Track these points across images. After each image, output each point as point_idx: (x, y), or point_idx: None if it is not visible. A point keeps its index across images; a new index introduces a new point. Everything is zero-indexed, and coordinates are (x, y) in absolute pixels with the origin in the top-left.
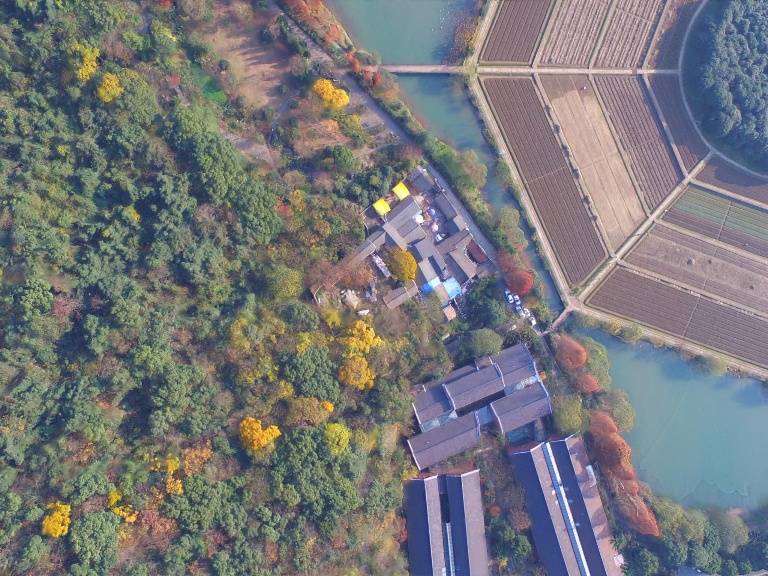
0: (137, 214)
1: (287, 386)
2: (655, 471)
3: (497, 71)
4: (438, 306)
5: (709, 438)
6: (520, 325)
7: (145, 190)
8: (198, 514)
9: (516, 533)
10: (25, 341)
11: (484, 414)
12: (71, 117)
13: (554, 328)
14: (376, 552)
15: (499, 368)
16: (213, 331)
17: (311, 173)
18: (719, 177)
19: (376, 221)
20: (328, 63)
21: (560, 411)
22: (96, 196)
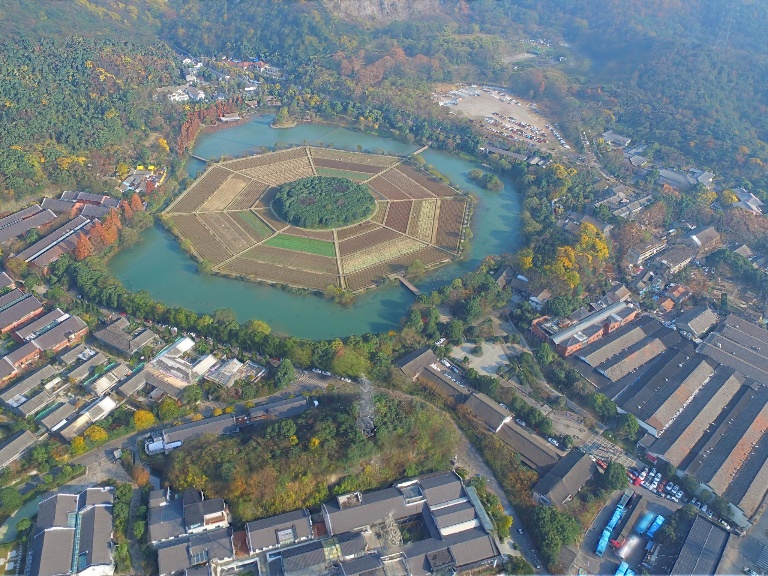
0: None
1: (41, 148)
2: None
3: None
4: None
5: None
6: None
7: None
8: None
9: None
10: (3, 112)
11: None
12: None
13: None
14: None
15: None
16: None
17: None
18: None
19: None
20: None
21: None
22: None
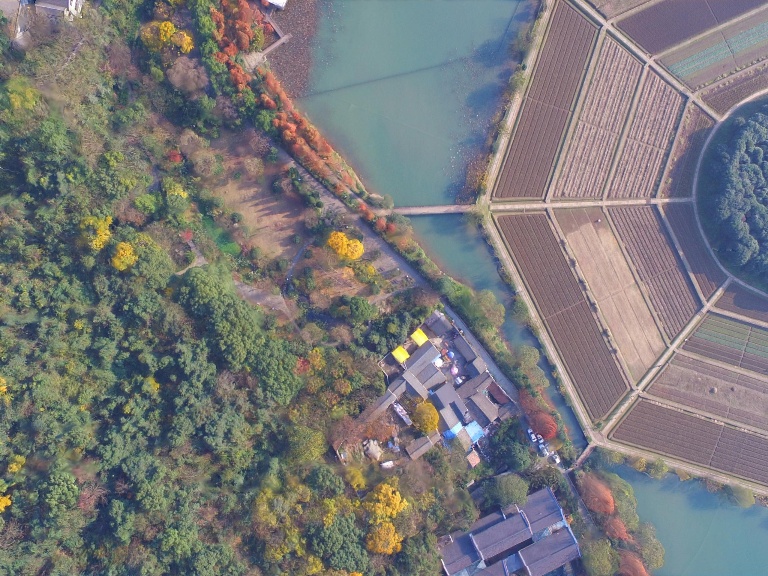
0: (157, 384)
1: (316, 562)
2: None
3: (510, 208)
4: (461, 452)
5: (739, 565)
6: (544, 464)
7: (164, 361)
8: None
9: None
10: (51, 536)
11: (512, 562)
12: (86, 284)
13: (578, 465)
14: None
15: (526, 516)
16: (238, 505)
17: (328, 320)
18: (738, 303)
19: (395, 368)
20: (340, 209)
21: (589, 555)
22: (114, 366)
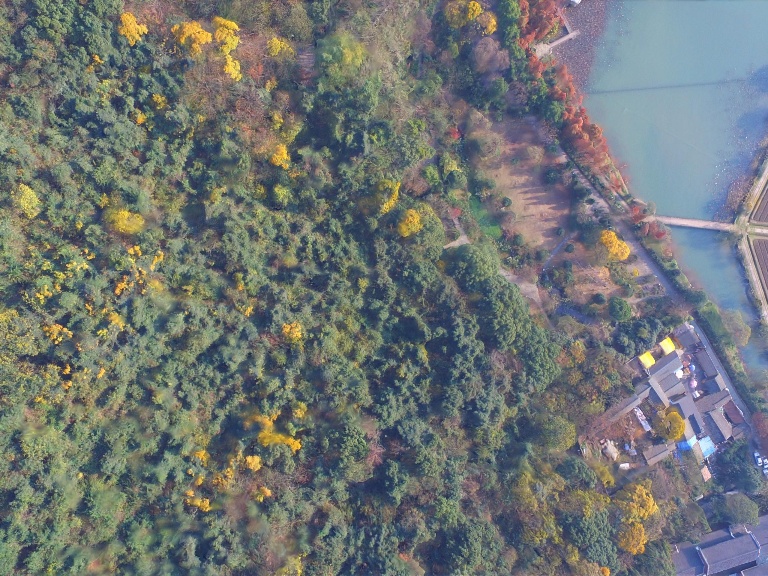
0: None
1: (574, 551)
2: None
3: (767, 232)
4: None
5: None
6: None
7: (439, 332)
8: None
9: None
10: (334, 485)
11: None
12: (362, 244)
13: None
14: None
15: (755, 538)
16: (499, 483)
17: (576, 316)
18: None
19: (638, 372)
20: (604, 209)
21: None
22: (384, 329)
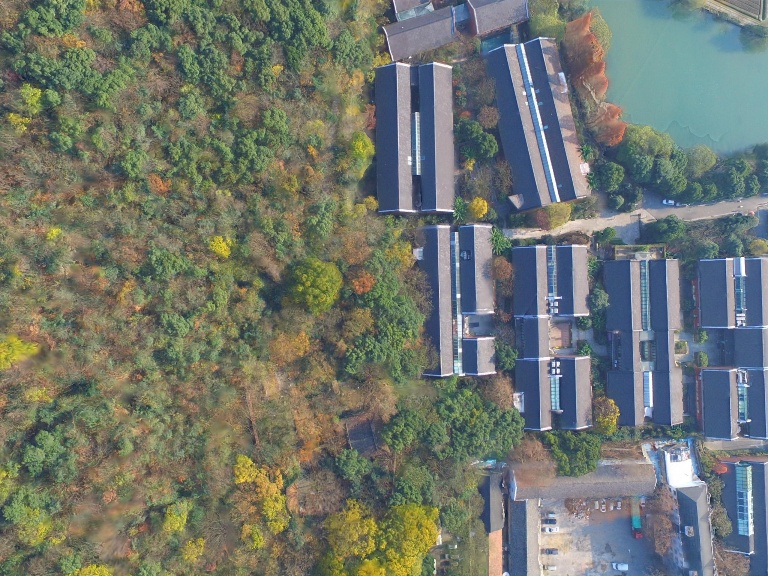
0: None
1: None
2: None
3: None
4: None
5: (684, 83)
6: None
7: None
8: (167, 0)
9: (484, 130)
10: None
11: (461, 11)
12: None
13: None
14: (343, 122)
15: None
16: None
17: None
18: None
19: None
20: None
21: None
22: None
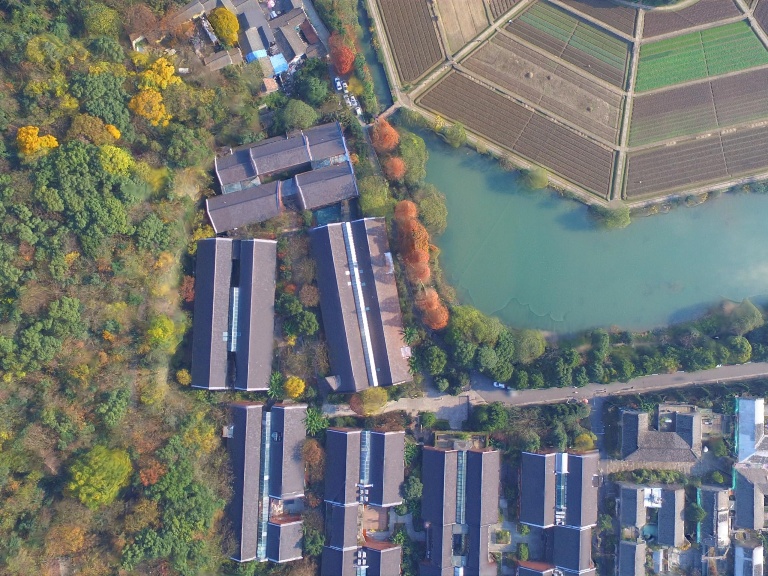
0: None
1: (71, 100)
2: (472, 290)
3: None
4: (260, 77)
5: (528, 258)
6: None
7: None
8: None
9: (304, 308)
10: None
11: (288, 186)
12: None
13: None
14: (154, 299)
15: (307, 139)
16: (13, 45)
17: None
18: None
19: None
20: None
21: None
22: None
